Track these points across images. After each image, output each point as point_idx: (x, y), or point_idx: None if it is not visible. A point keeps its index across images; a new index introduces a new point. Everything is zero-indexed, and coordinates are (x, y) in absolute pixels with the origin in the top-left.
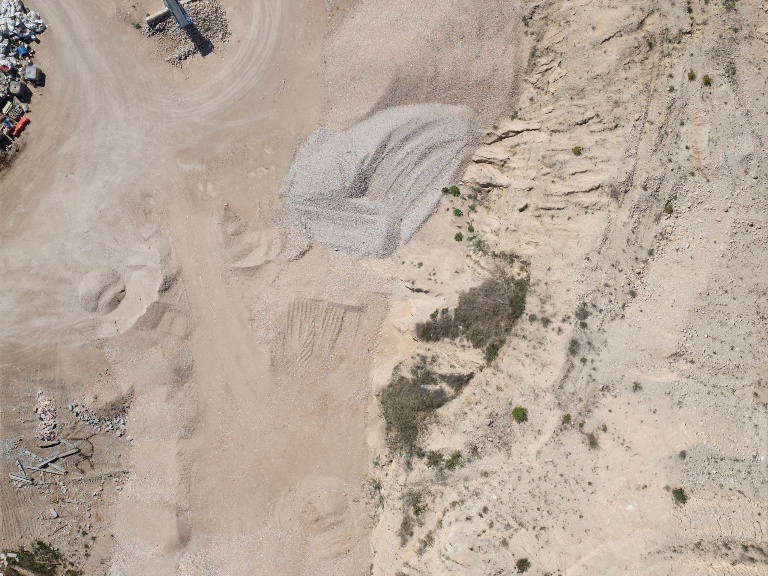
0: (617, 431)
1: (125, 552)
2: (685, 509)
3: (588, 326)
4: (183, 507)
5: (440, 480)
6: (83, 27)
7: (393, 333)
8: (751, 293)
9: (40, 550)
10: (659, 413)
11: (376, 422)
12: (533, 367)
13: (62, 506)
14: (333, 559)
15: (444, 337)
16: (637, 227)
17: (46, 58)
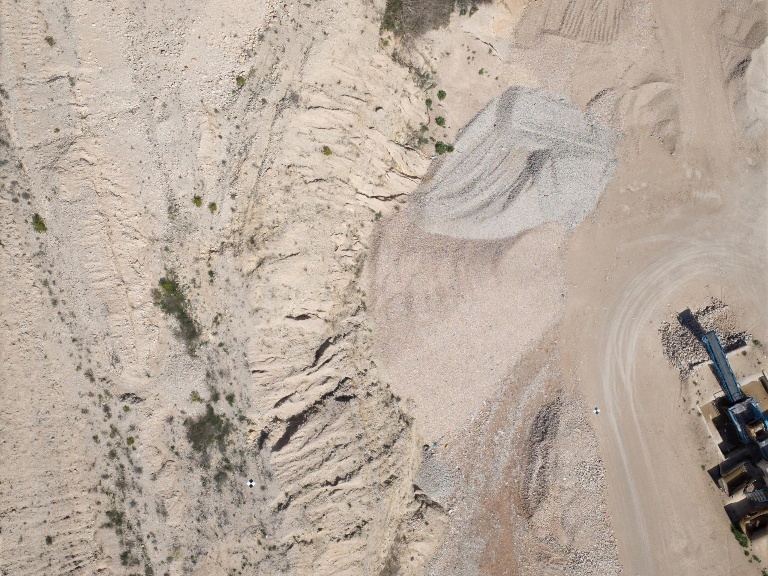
0: None
1: None
2: None
3: None
4: None
5: None
6: None
7: (512, 4)
8: None
9: None
10: None
11: None
12: None
13: None
14: None
15: None
16: (274, 64)
17: None
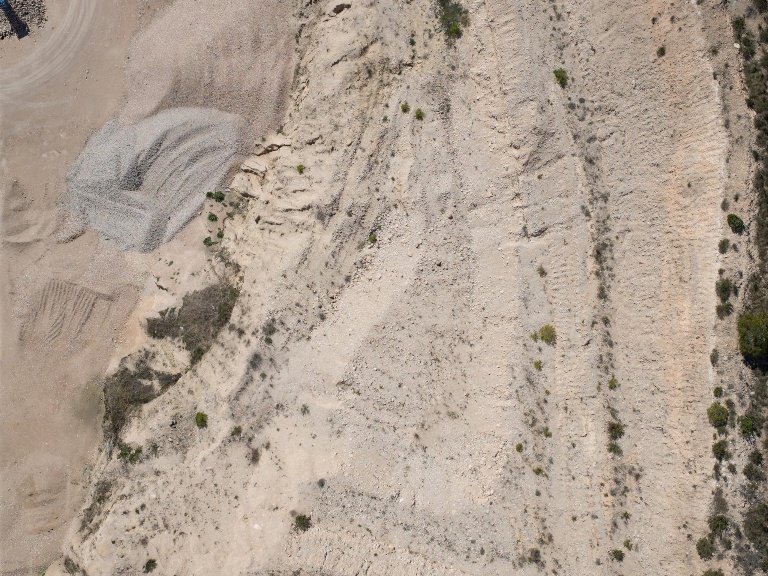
0: (277, 450)
1: None
2: (301, 536)
3: (273, 342)
4: None
5: (125, 473)
6: None
7: (136, 326)
8: (428, 333)
9: None
10: (318, 439)
11: None
12: (221, 375)
13: None
14: (36, 535)
15: (167, 335)
16: (338, 252)
17: None
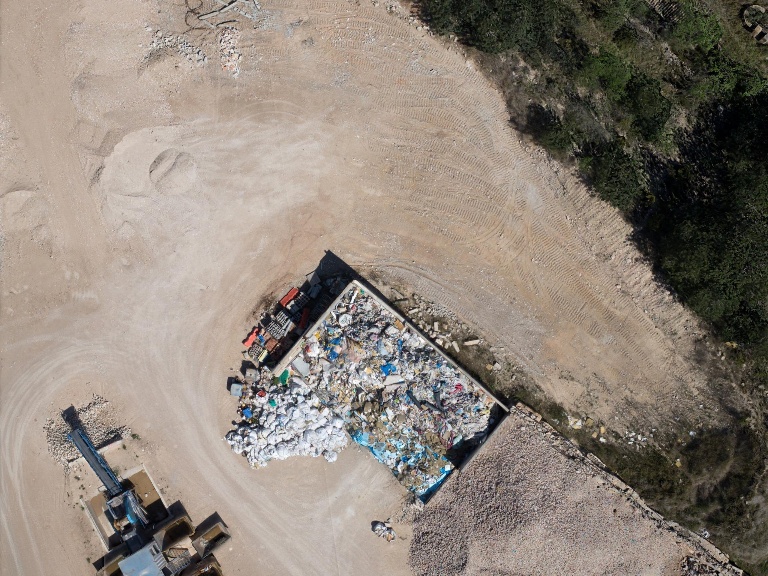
0: None
1: None
2: None
3: None
4: None
5: None
6: (189, 437)
7: None
8: None
9: None
10: None
11: None
12: None
13: None
14: None
15: None
16: None
17: (226, 406)
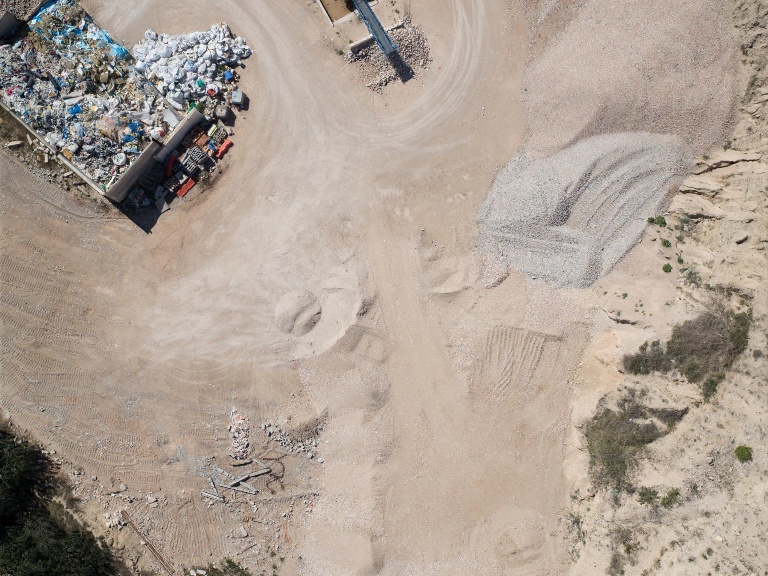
0: None
1: (314, 575)
2: None
3: None
4: (377, 532)
5: (654, 518)
6: (287, 53)
7: (595, 364)
8: None
9: (229, 568)
10: None
11: (575, 455)
12: (759, 405)
13: (252, 525)
14: None
15: (654, 370)
16: None
17: (250, 83)
